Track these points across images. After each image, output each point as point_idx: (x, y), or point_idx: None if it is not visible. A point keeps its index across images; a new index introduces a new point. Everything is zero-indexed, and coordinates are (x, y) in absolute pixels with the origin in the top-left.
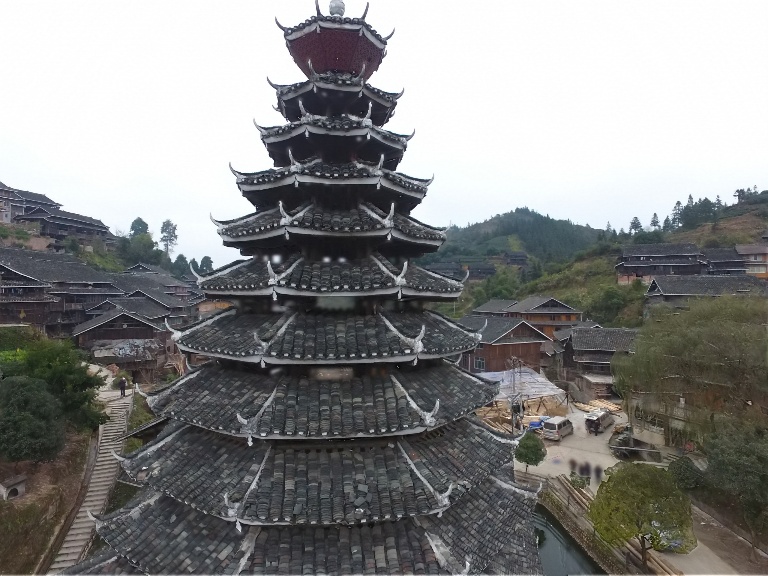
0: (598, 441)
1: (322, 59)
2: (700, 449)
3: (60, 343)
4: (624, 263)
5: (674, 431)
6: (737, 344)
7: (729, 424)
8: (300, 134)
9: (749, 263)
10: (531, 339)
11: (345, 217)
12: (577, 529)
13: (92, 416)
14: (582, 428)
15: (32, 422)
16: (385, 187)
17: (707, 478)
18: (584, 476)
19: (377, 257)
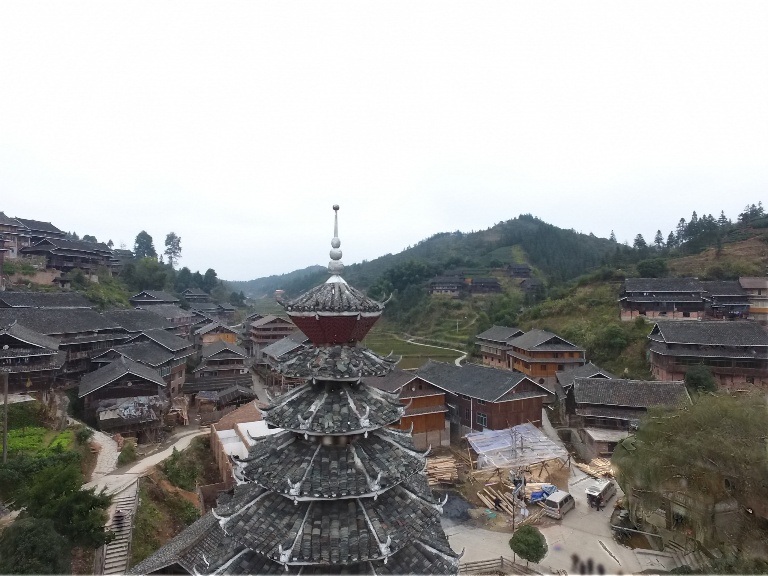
0: (600, 519)
1: (321, 335)
2: (701, 549)
3: (66, 469)
4: (627, 298)
5: (676, 515)
6: (737, 465)
7: (729, 554)
8: (299, 433)
9: (753, 298)
10: (533, 394)
11: (343, 526)
12: None
13: (98, 537)
14: (584, 500)
15: (39, 568)
16: (382, 493)
17: None
18: (585, 570)
19: (374, 568)
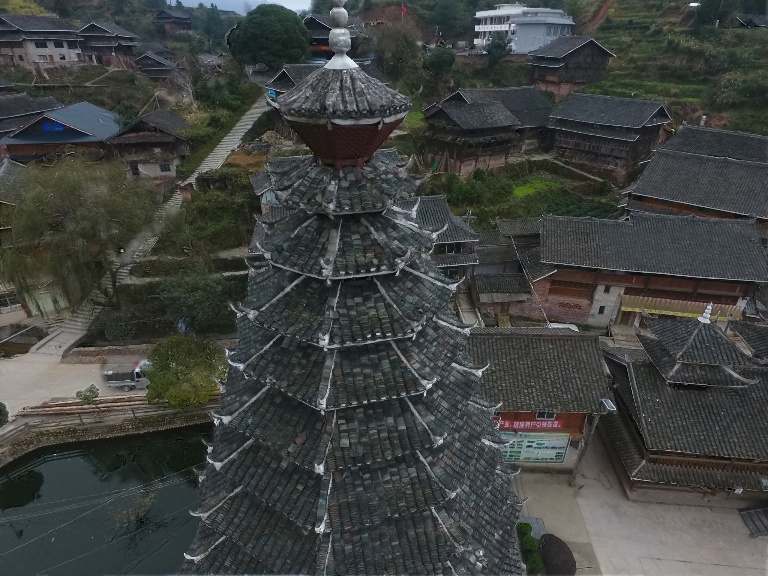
0: None
1: None
2: (96, 303)
3: None
4: None
5: None
6: (134, 213)
7: None
8: None
9: None
10: None
11: None
12: (114, 428)
13: None
14: None
15: None
16: None
17: (104, 321)
18: (29, 394)
19: None
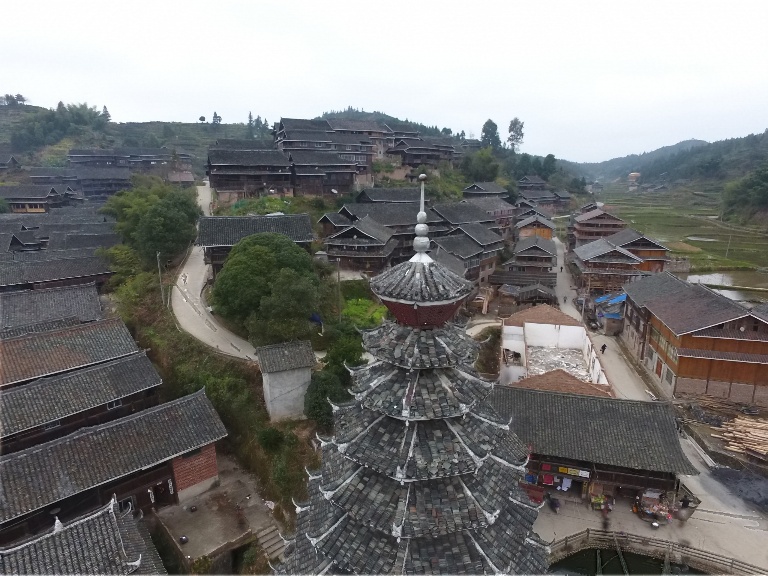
0: None
1: None
2: None
3: (351, 343)
4: None
5: None
6: None
7: None
8: None
9: None
10: None
11: (382, 492)
12: None
13: None
14: None
15: (328, 406)
16: (411, 481)
17: None
18: None
19: None
